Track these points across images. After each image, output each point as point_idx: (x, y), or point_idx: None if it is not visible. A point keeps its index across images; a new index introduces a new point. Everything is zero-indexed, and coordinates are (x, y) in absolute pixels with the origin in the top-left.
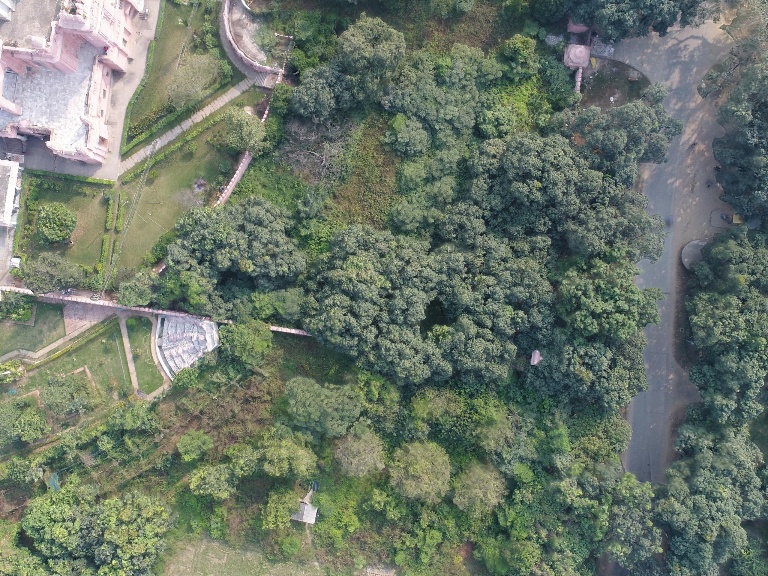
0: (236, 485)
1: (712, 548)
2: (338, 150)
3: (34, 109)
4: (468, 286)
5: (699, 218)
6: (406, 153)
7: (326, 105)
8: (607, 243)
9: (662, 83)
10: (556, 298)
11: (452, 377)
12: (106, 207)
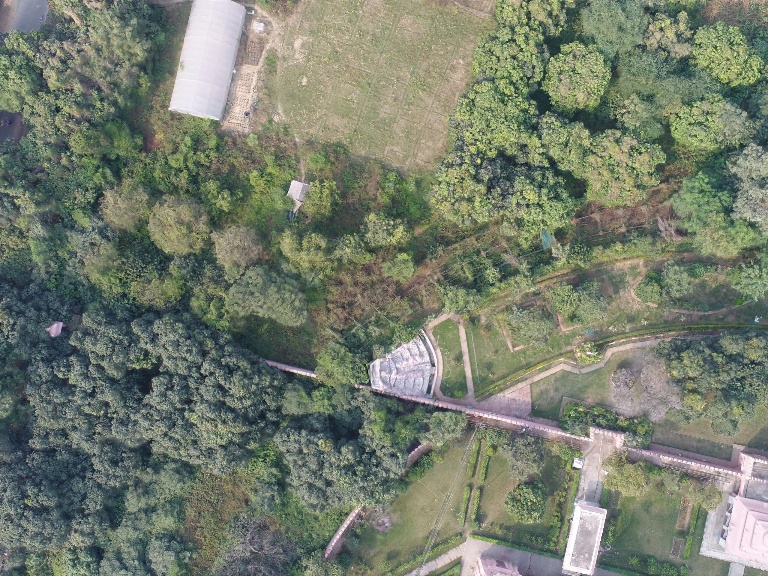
0: None
1: None
2: None
3: None
4: None
5: None
6: (173, 538)
7: None
8: None
9: None
10: None
11: None
12: (481, 512)
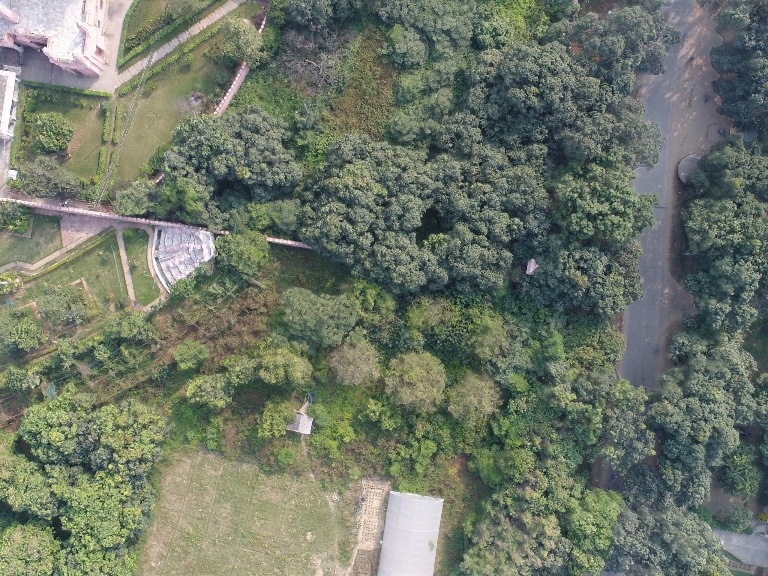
0: (232, 397)
1: (705, 450)
2: (335, 62)
3: (31, 17)
4: (464, 194)
5: (696, 133)
6: (403, 65)
7: (323, 12)
8: (603, 149)
9: None
10: (552, 205)
11: (448, 287)
12: (103, 119)
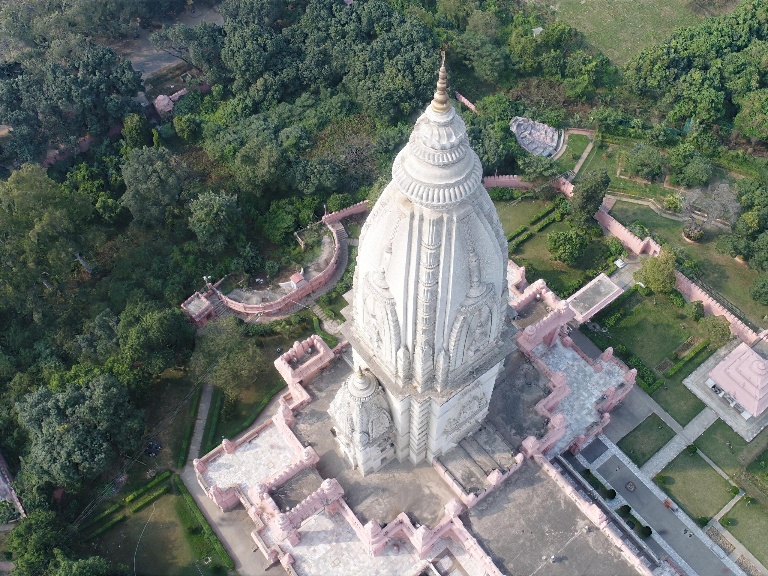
0: None
1: None
2: None
3: None
4: None
5: None
6: None
7: None
8: None
9: (142, 75)
10: None
11: None
12: (522, 248)
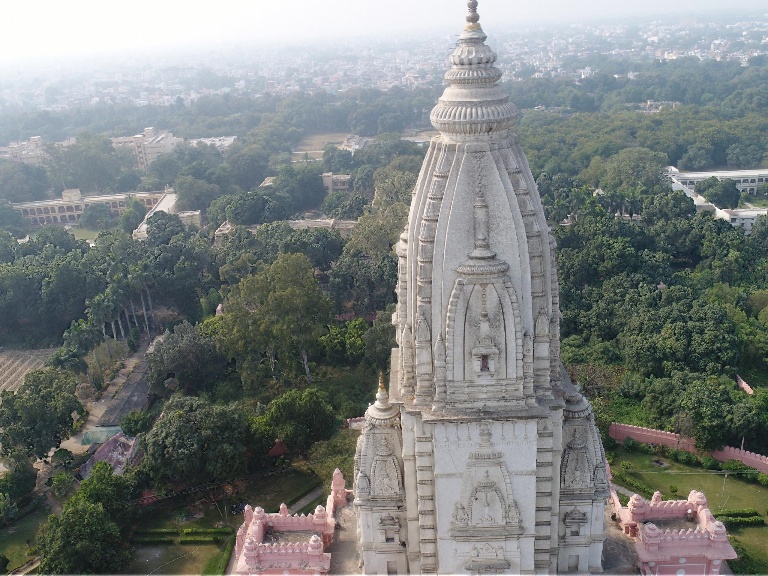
0: None
1: None
2: None
3: None
4: None
5: None
6: None
7: None
8: None
9: None
10: None
11: None
12: (741, 529)
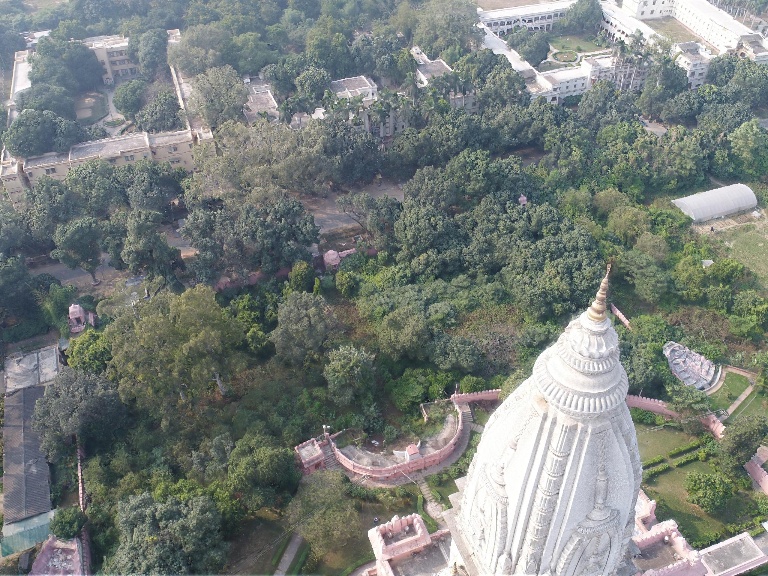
0: None
1: None
2: None
3: None
4: None
5: None
6: None
7: None
8: None
9: (320, 229)
10: None
11: None
12: (656, 479)
